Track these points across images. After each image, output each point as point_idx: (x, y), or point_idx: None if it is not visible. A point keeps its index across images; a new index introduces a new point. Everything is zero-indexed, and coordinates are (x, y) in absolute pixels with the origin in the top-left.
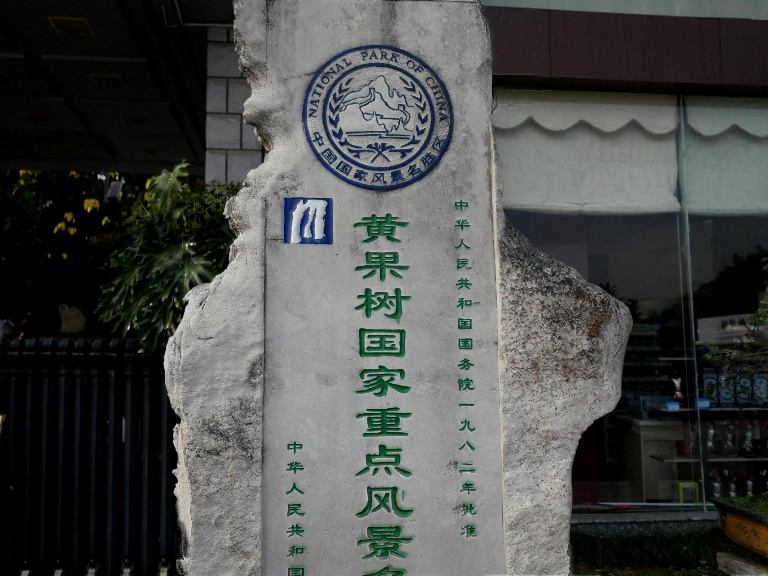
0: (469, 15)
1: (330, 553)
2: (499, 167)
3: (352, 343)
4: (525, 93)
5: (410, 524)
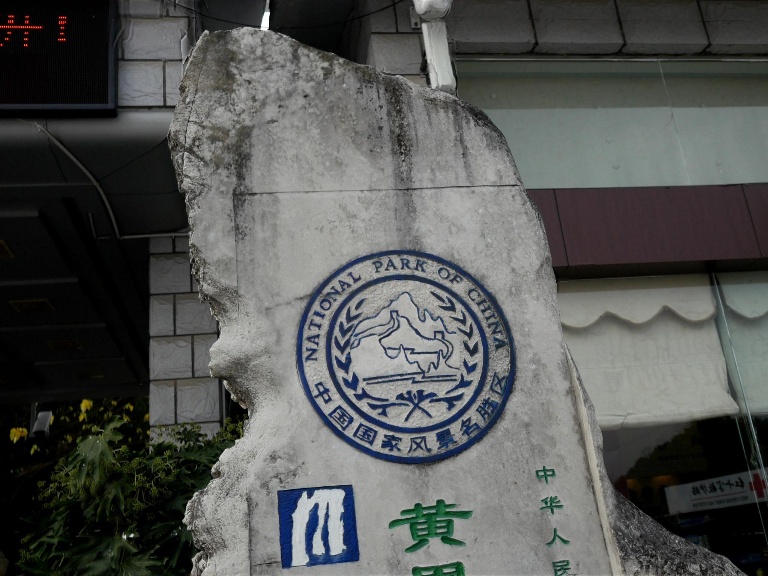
0: (513, 202)
1: None
2: (592, 411)
3: None
4: None
5: None
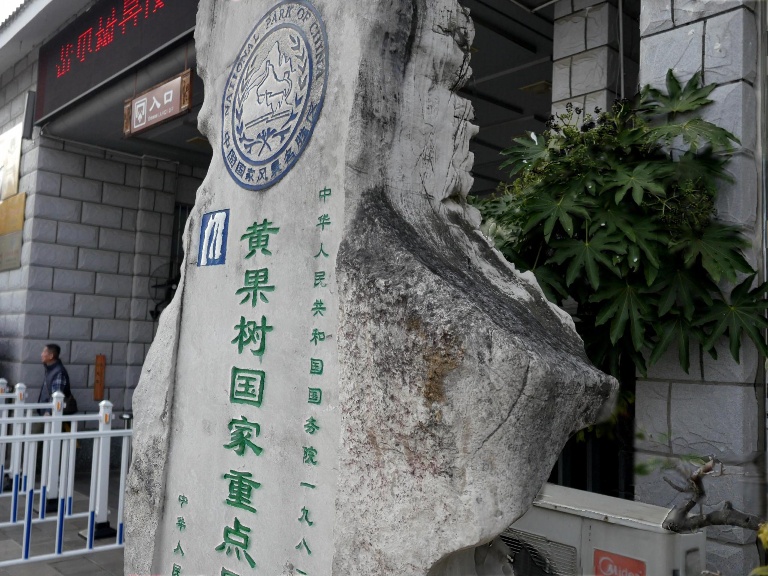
0: None
1: None
2: (354, 128)
3: (226, 384)
4: None
5: None
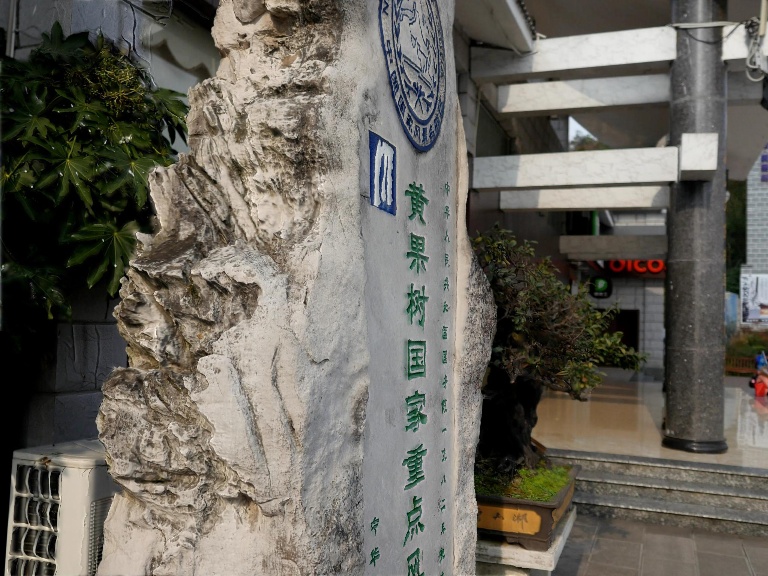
0: None
1: None
2: None
3: (405, 361)
4: (193, 12)
5: None
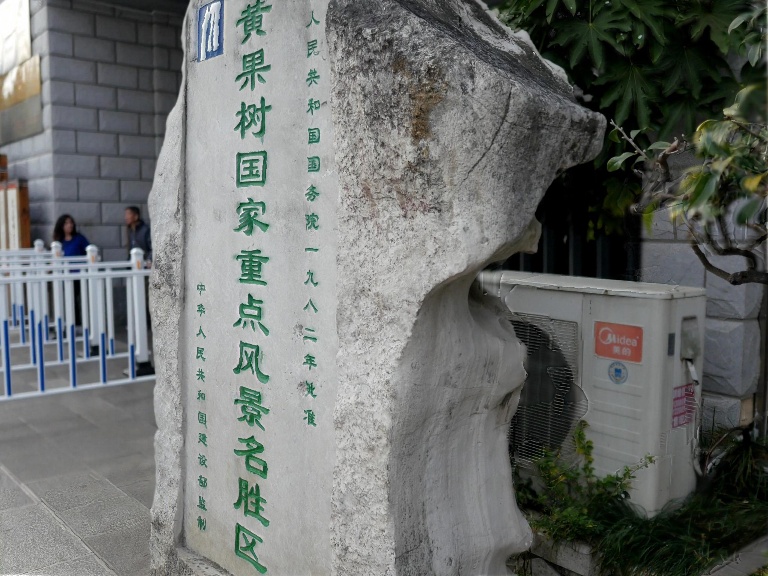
0: None
1: (219, 405)
2: None
3: (232, 171)
4: None
5: (267, 392)
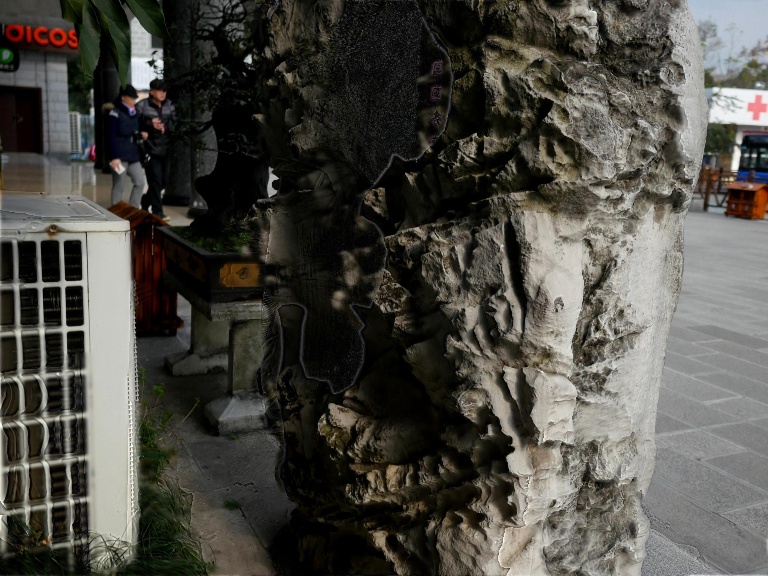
0: None
1: None
2: None
3: None
4: None
5: None
